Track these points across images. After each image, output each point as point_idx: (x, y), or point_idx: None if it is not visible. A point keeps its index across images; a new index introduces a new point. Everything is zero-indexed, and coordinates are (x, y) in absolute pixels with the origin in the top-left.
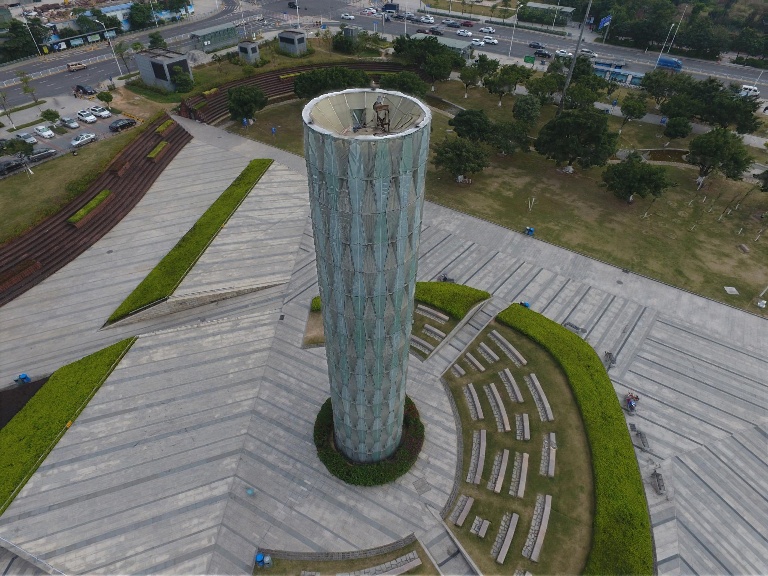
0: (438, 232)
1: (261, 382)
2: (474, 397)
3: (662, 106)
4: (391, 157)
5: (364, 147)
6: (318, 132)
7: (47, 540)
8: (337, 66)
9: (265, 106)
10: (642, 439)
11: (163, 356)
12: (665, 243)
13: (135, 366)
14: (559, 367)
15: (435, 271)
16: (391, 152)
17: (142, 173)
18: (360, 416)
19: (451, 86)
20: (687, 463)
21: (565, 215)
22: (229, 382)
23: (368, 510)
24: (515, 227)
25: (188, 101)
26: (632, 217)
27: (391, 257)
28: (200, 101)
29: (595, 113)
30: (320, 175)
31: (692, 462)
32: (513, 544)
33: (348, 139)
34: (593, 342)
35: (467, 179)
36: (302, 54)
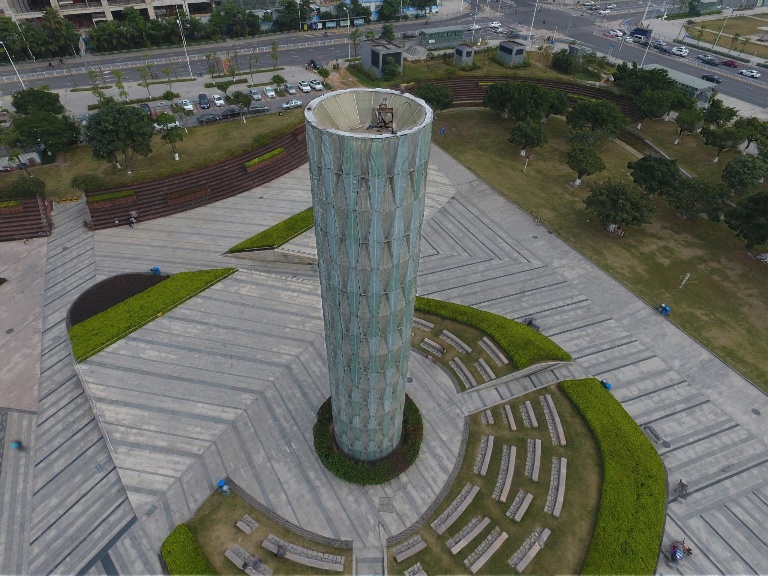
0: (553, 274)
1: (307, 345)
2: (488, 450)
3: None
4: (361, 157)
5: (336, 140)
6: (306, 118)
7: (104, 388)
8: (531, 82)
9: (452, 108)
10: None
11: (247, 292)
12: None
13: (224, 291)
14: (601, 467)
15: (525, 312)
16: None
17: None
18: (342, 406)
19: (664, 128)
20: None
21: (726, 308)
22: (283, 334)
23: (327, 497)
24: (649, 299)
25: None
26: None
27: (365, 258)
28: None
29: None
30: None
31: None
32: None
33: (321, 129)
34: (671, 462)
35: (620, 231)
36: (516, 65)
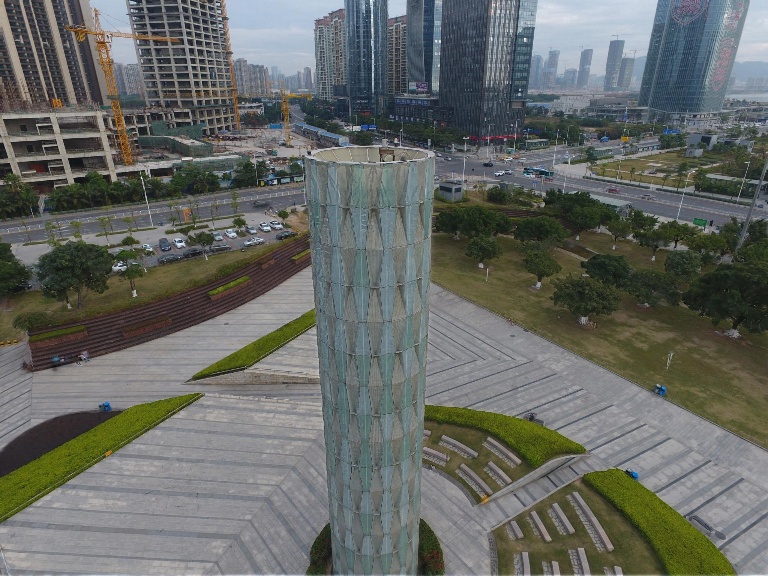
0: (541, 369)
1: (289, 471)
2: (525, 572)
3: None
4: (370, 186)
5: (343, 172)
6: (308, 158)
7: (27, 556)
8: None
9: None
10: None
11: (215, 418)
12: None
13: (188, 419)
14: (663, 570)
15: (524, 408)
16: None
17: (282, 270)
18: (348, 526)
19: (599, 238)
20: None
21: (718, 383)
22: (259, 461)
23: None
24: (642, 382)
25: None
26: None
27: (376, 308)
28: None
29: (765, 268)
30: None
31: None
32: None
33: (327, 162)
34: (734, 556)
35: (592, 322)
36: (457, 201)
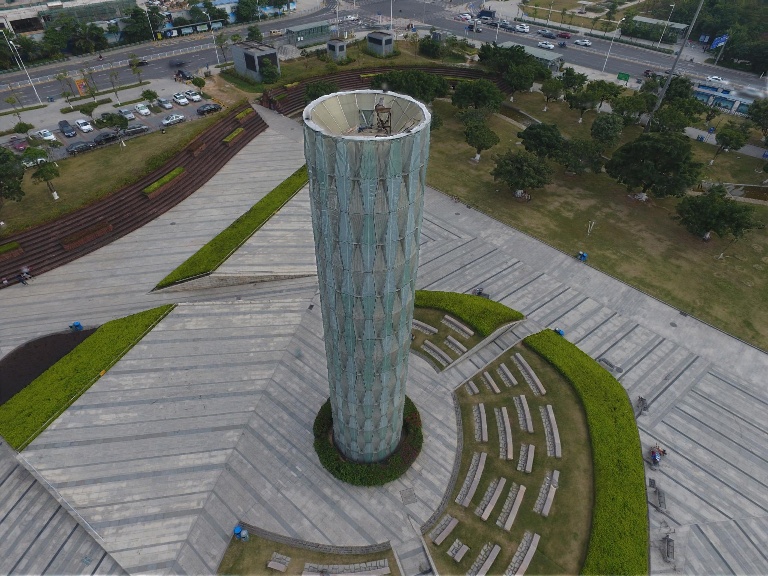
0: (484, 245)
1: (278, 365)
2: (482, 418)
3: (767, 138)
4: (379, 159)
5: (351, 147)
6: (310, 128)
7: (63, 471)
8: (414, 69)
9: None
10: (659, 498)
11: (195, 326)
12: (738, 290)
13: (169, 331)
14: (580, 403)
15: (472, 284)
16: (381, 154)
17: (216, 155)
18: (352, 414)
19: (532, 98)
20: (708, 535)
21: (627, 244)
22: (248, 360)
23: (350, 508)
24: (568, 250)
25: (270, 92)
26: (705, 256)
27: (380, 260)
28: (281, 93)
29: (678, 139)
30: (313, 170)
31: (714, 535)
32: (488, 575)
33: (335, 137)
34: (627, 384)
35: (527, 194)
36: (387, 55)
